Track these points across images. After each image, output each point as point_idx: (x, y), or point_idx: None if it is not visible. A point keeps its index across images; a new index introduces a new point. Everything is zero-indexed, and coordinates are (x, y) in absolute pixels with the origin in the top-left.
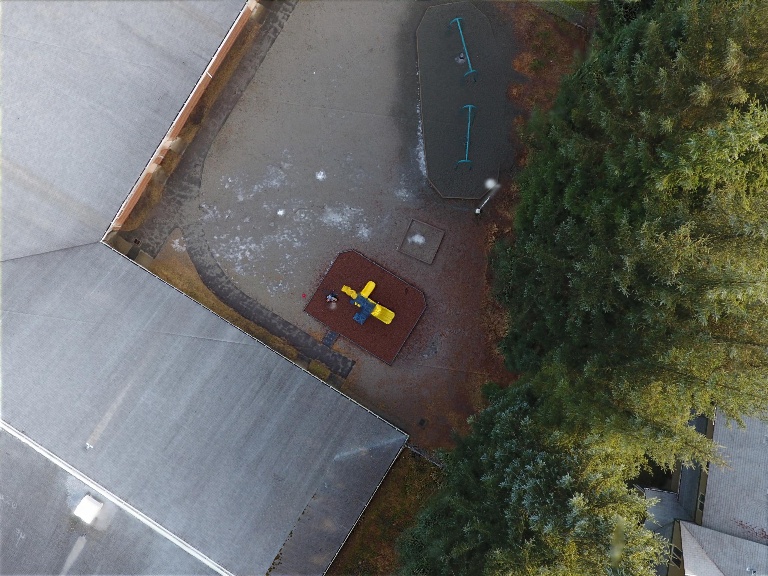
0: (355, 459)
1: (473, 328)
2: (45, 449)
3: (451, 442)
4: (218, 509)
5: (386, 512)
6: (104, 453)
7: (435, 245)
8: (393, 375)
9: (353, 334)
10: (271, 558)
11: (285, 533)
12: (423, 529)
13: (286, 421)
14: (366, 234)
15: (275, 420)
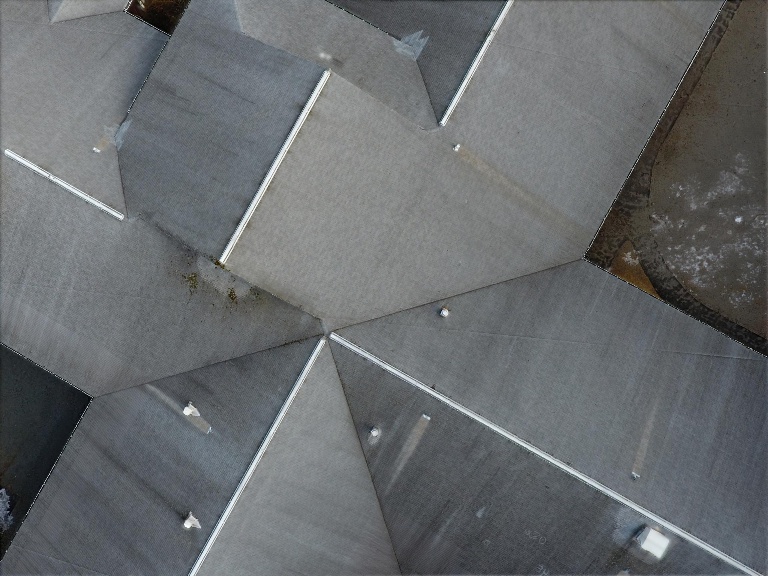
0: None
1: None
2: (595, 481)
3: None
4: None
5: None
6: (653, 482)
7: None
8: None
9: None
10: None
11: None
12: None
13: None
14: None
15: None
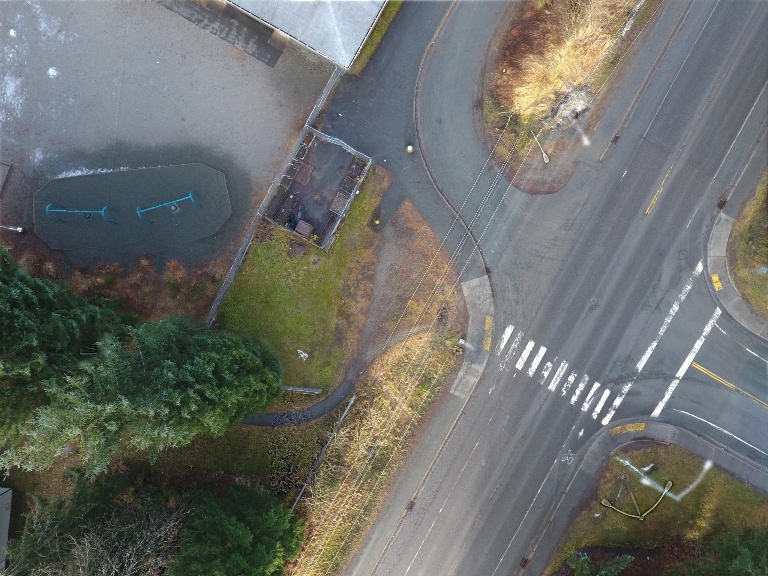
0: None
1: None
2: None
3: None
4: None
5: None
6: None
7: None
8: None
9: None
10: None
11: None
12: None
13: None
14: None
15: None
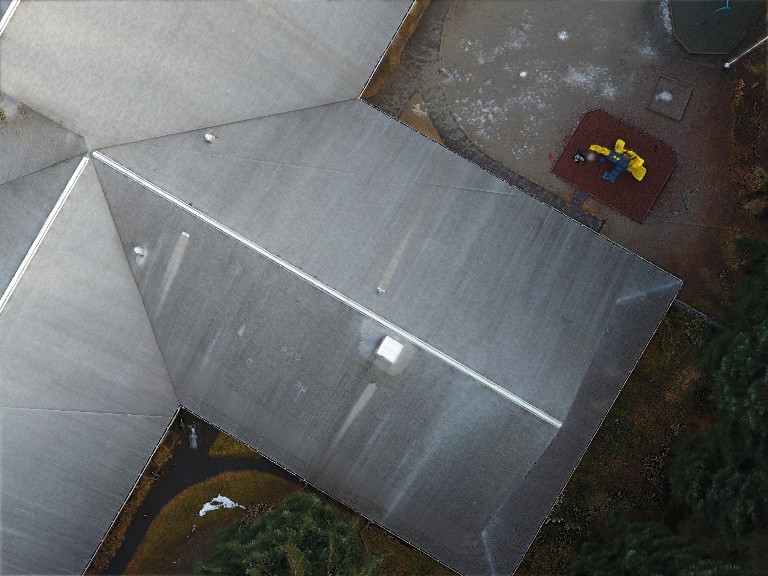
0: (635, 304)
1: (722, 184)
2: (340, 293)
3: (704, 298)
4: (515, 349)
5: (642, 369)
6: (397, 297)
7: (684, 101)
8: (644, 233)
9: (602, 193)
10: (573, 394)
11: (582, 371)
12: (679, 385)
13: (565, 267)
14: (611, 93)
15: (554, 266)
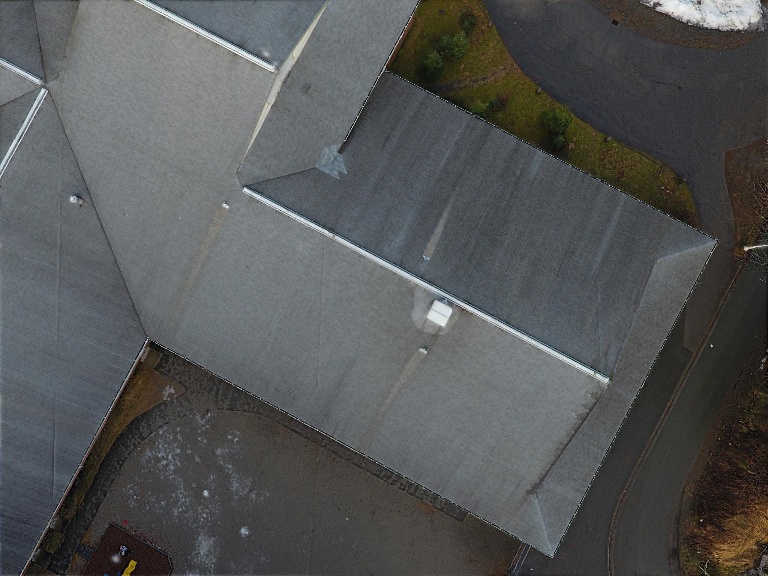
0: None
1: None
2: None
3: None
4: None
5: None
6: None
7: None
8: None
9: (91, 573)
10: None
11: None
12: None
13: None
14: None
15: None
